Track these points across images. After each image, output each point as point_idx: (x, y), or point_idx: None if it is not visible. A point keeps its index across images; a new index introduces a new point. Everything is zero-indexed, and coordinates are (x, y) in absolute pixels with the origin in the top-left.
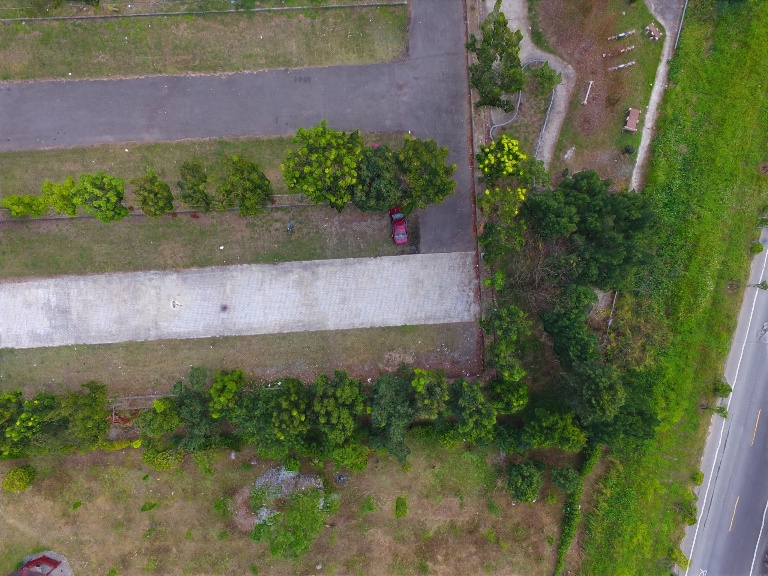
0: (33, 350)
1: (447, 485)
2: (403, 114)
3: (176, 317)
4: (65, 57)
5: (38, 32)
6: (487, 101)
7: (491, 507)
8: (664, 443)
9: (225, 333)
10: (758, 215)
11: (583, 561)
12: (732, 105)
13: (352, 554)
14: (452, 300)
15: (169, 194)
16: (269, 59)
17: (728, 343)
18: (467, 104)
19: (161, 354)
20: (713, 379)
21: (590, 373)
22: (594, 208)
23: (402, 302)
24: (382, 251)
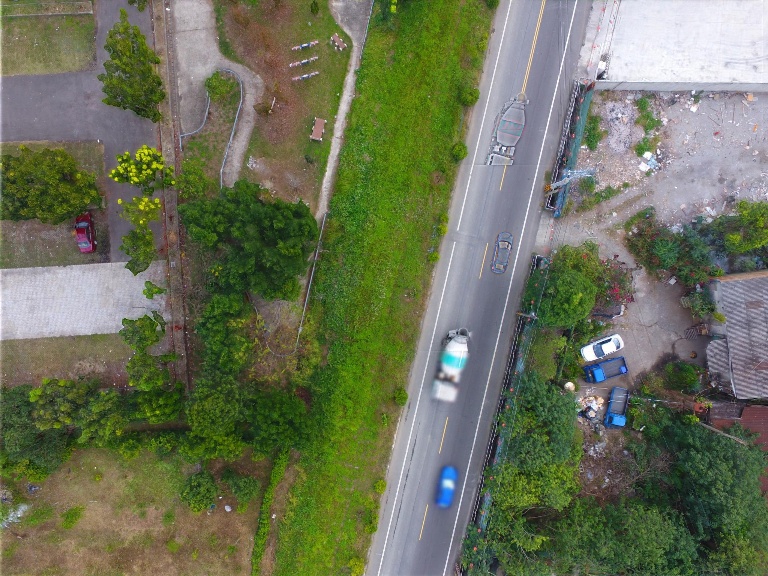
0: None
1: (141, 495)
2: (91, 123)
3: None
4: None
5: None
6: (136, 111)
7: (186, 517)
8: (343, 452)
9: None
10: (434, 224)
11: (272, 571)
12: (404, 115)
13: (45, 565)
14: (143, 309)
15: None
16: None
17: (408, 351)
18: None
19: None
20: (393, 387)
21: (198, 383)
22: None
23: (92, 311)
24: (72, 260)
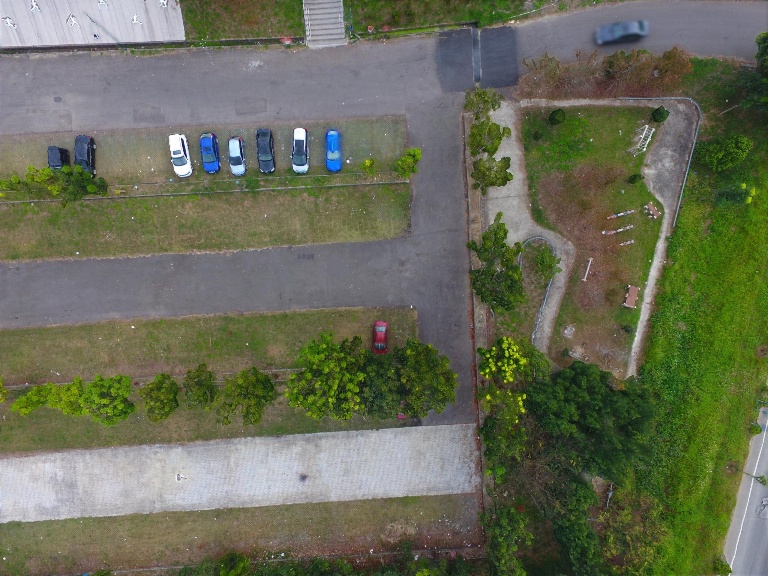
0: (40, 523)
1: None
2: (405, 289)
3: (181, 490)
4: (73, 237)
5: (46, 213)
6: None
7: None
8: None
9: (229, 505)
10: (756, 396)
11: None
12: (730, 290)
13: None
14: (453, 472)
15: (175, 389)
16: (273, 237)
17: (727, 521)
18: (468, 279)
19: (166, 526)
20: (712, 557)
21: None
22: (594, 406)
23: (404, 474)
24: (384, 423)
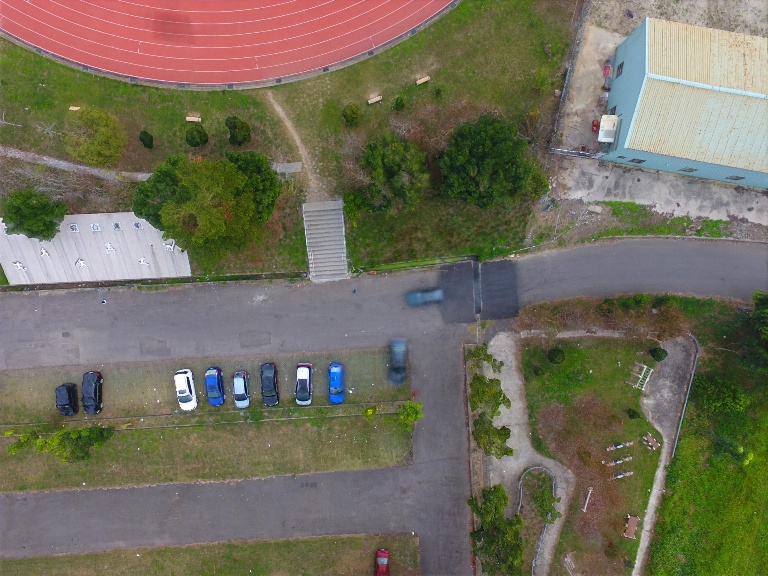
0: None
1: None
2: (407, 516)
3: None
4: (80, 468)
5: None
6: None
7: None
8: None
9: None
10: None
11: None
12: (729, 530)
13: None
14: None
15: None
16: (277, 466)
17: None
18: (469, 506)
19: None
20: None
21: None
22: None
23: None
24: None
